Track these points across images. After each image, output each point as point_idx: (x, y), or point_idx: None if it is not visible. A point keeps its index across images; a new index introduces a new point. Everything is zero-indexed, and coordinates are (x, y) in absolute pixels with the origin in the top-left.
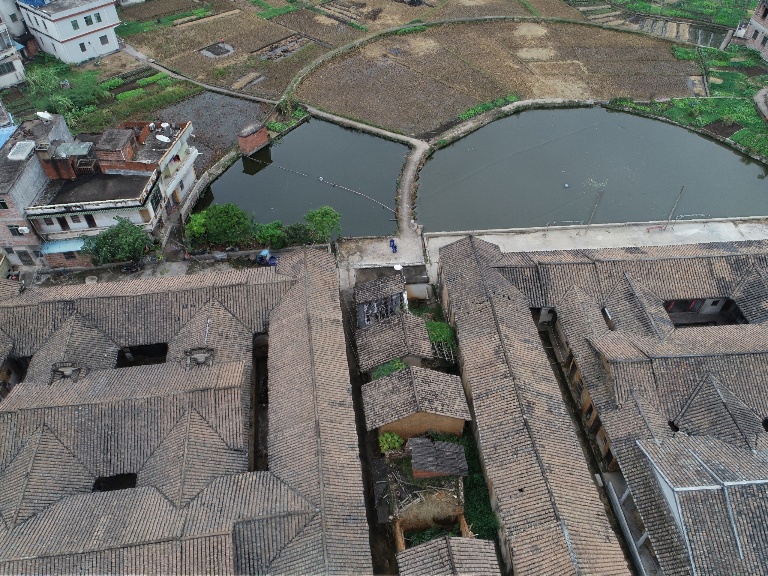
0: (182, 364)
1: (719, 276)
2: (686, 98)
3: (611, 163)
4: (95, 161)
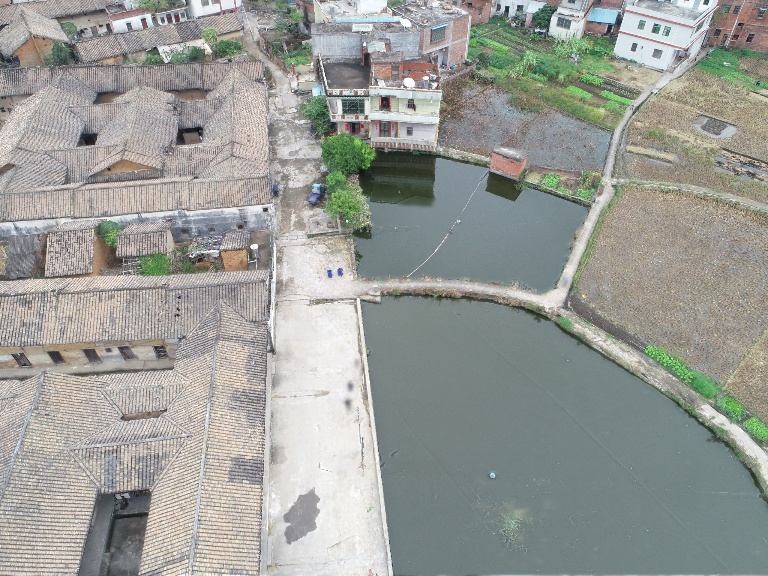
0: None
1: (164, 574)
2: None
3: (584, 570)
4: None
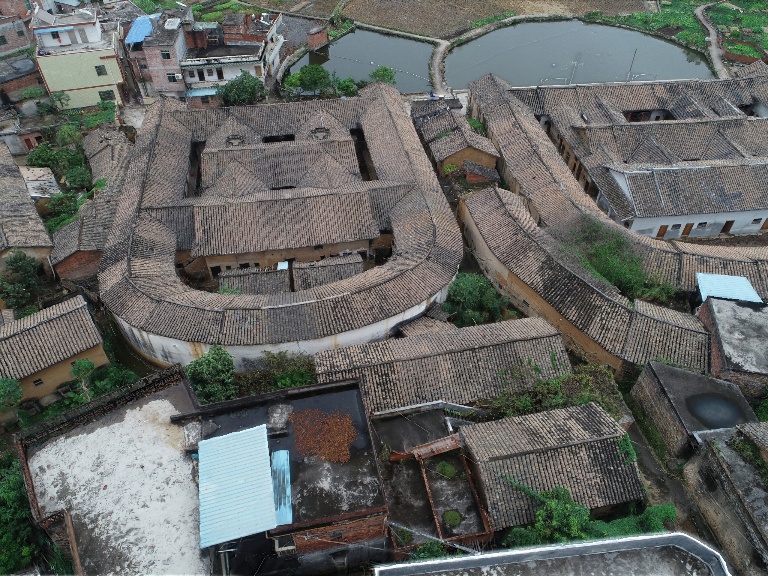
0: (309, 139)
1: (659, 96)
2: (643, 13)
3: (586, 52)
4: (218, 36)
